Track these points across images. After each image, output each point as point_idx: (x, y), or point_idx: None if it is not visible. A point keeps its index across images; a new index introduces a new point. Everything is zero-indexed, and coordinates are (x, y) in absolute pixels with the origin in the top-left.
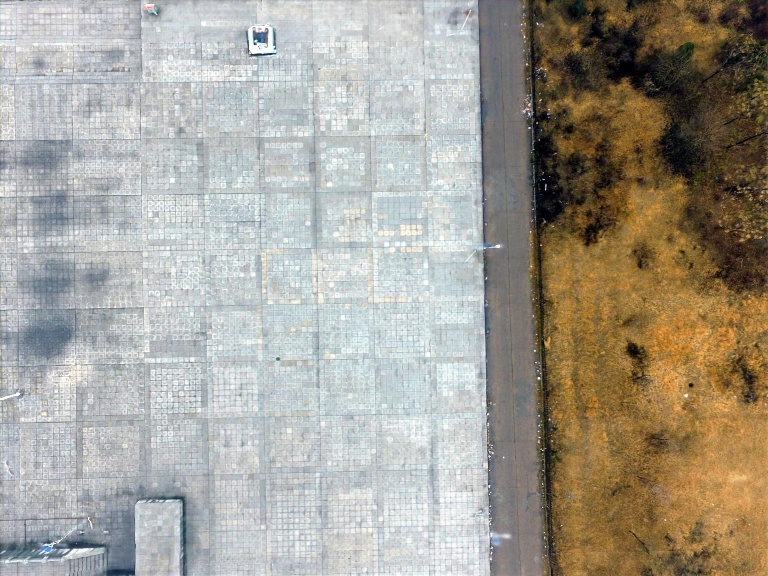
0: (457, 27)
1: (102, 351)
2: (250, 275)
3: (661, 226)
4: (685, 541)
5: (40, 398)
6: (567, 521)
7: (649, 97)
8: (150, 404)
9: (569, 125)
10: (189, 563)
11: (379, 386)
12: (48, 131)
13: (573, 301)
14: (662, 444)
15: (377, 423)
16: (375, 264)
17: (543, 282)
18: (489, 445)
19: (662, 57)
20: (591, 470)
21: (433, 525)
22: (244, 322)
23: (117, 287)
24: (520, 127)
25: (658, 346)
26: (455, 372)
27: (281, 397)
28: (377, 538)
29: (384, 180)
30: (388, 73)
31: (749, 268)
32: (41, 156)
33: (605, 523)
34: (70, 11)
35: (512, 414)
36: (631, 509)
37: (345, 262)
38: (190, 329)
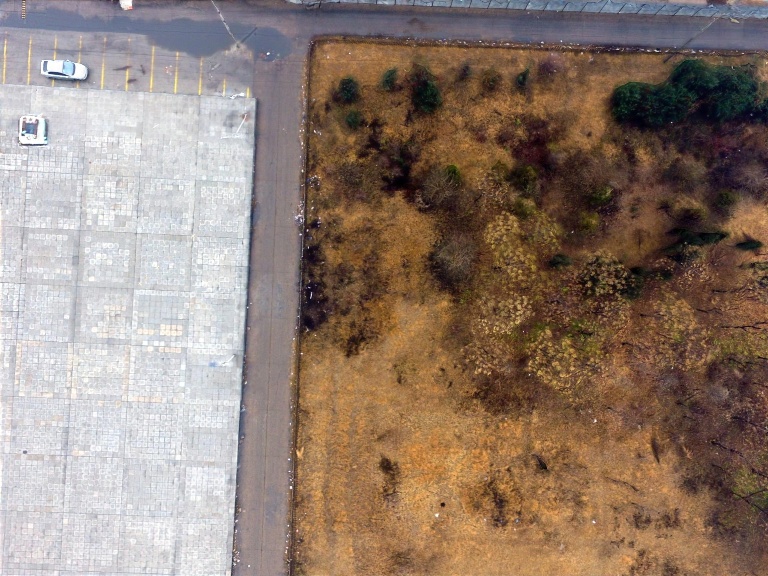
0: (232, 130)
1: None
2: (3, 365)
3: (423, 342)
4: None
5: None
6: None
7: (421, 212)
8: None
9: (337, 235)
10: None
11: (126, 486)
12: None
13: (329, 412)
14: (408, 563)
15: (121, 524)
16: (132, 362)
17: (301, 391)
18: (235, 552)
19: (429, 176)
20: None
21: None
22: None
23: None
24: (291, 233)
25: (411, 463)
26: (205, 477)
27: (25, 491)
28: None
29: (147, 278)
30: (159, 171)
31: (508, 391)
32: None
33: None
34: None
35: (261, 522)
36: None
37: (101, 358)
38: None
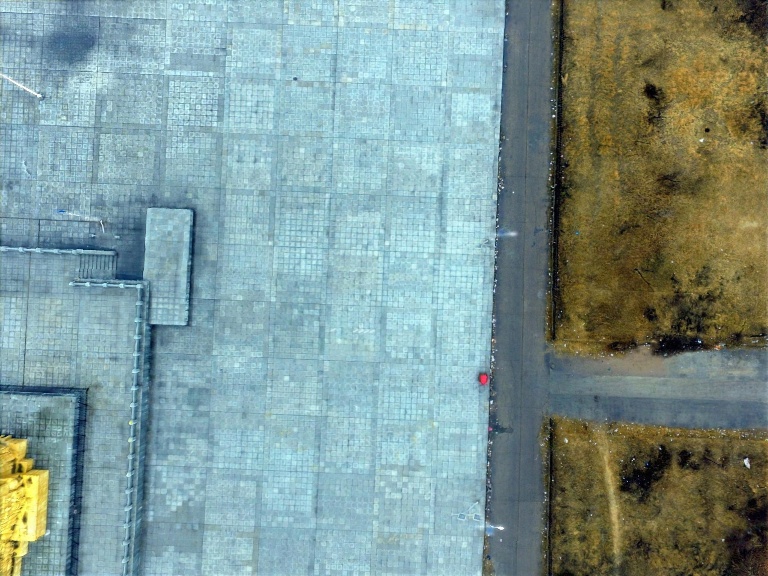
0: None
1: (123, 60)
2: None
3: None
4: (691, 284)
5: (61, 102)
6: (573, 257)
7: None
8: (167, 115)
9: None
10: (196, 273)
11: (394, 112)
12: None
13: (593, 38)
14: (674, 186)
15: (389, 148)
16: None
17: (564, 18)
18: (500, 179)
19: None
20: (600, 208)
21: (439, 253)
22: (264, 40)
23: None
24: None
25: (676, 88)
26: (470, 103)
27: (296, 117)
28: (382, 262)
29: None
30: None
31: None
32: None
33: (611, 261)
34: None
35: (524, 150)
36: (638, 249)
37: None
38: (210, 44)
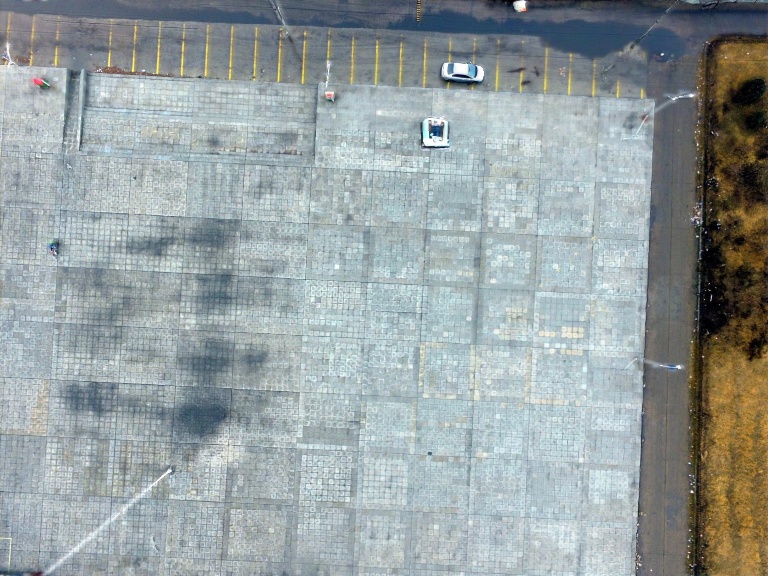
0: (632, 131)
1: (255, 433)
2: (408, 367)
3: None
4: None
5: (191, 476)
6: None
7: None
8: (299, 490)
9: (740, 237)
10: None
11: (530, 488)
12: (218, 210)
13: (733, 416)
14: None
15: (526, 526)
16: (534, 364)
17: (703, 395)
18: (637, 556)
19: None
20: None
21: None
22: (398, 414)
23: (275, 370)
24: (688, 235)
25: None
26: (608, 480)
27: (431, 492)
28: None
29: (548, 280)
30: (559, 173)
31: None
32: (209, 234)
33: None
34: (247, 91)
35: (662, 526)
36: None
37: (504, 360)
38: (344, 417)
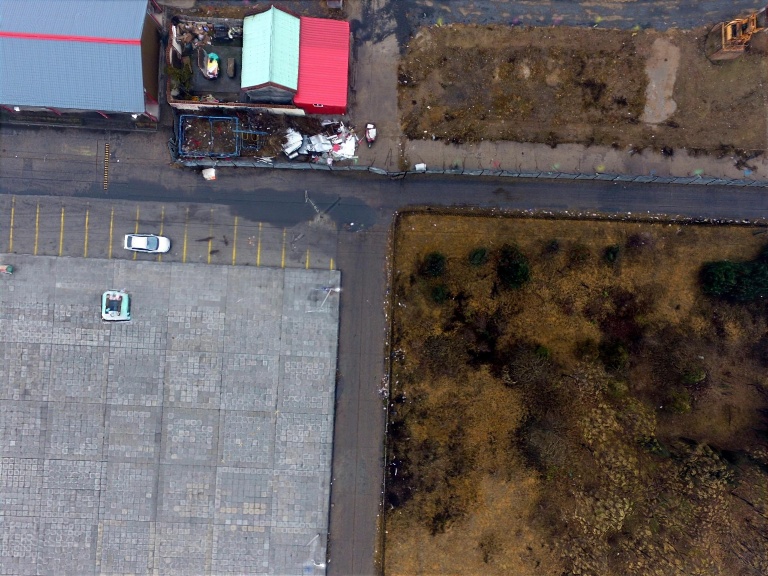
0: (317, 304)
1: None
2: (85, 546)
3: (510, 521)
4: None
5: None
6: None
7: (507, 387)
8: None
9: (423, 411)
10: None
11: None
12: None
13: None
14: None
15: None
16: (215, 542)
17: (386, 571)
18: None
19: (518, 356)
20: None
21: None
22: None
23: None
24: (375, 407)
25: None
26: None
27: None
28: None
29: (230, 455)
30: (243, 346)
31: None
32: None
33: None
34: None
35: None
36: None
37: (184, 538)
38: None
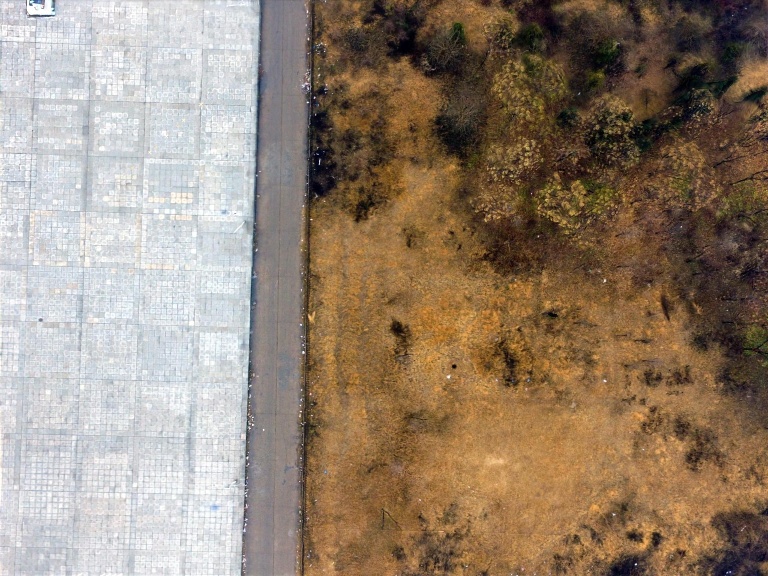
0: None
1: None
2: (17, 235)
3: (432, 206)
4: (439, 522)
5: None
6: (321, 496)
7: (427, 77)
8: None
9: (345, 101)
10: None
11: (141, 352)
12: None
13: (340, 277)
14: (421, 424)
15: (137, 389)
16: (143, 230)
17: (311, 256)
18: (249, 417)
19: (435, 37)
20: (349, 446)
21: (187, 494)
22: (9, 281)
23: None
24: (298, 101)
25: (422, 326)
26: (218, 342)
27: (42, 358)
28: (130, 504)
29: (157, 147)
30: (166, 41)
31: (517, 252)
32: None
33: (359, 500)
34: None
35: (275, 387)
36: (386, 487)
37: (114, 227)
38: None
